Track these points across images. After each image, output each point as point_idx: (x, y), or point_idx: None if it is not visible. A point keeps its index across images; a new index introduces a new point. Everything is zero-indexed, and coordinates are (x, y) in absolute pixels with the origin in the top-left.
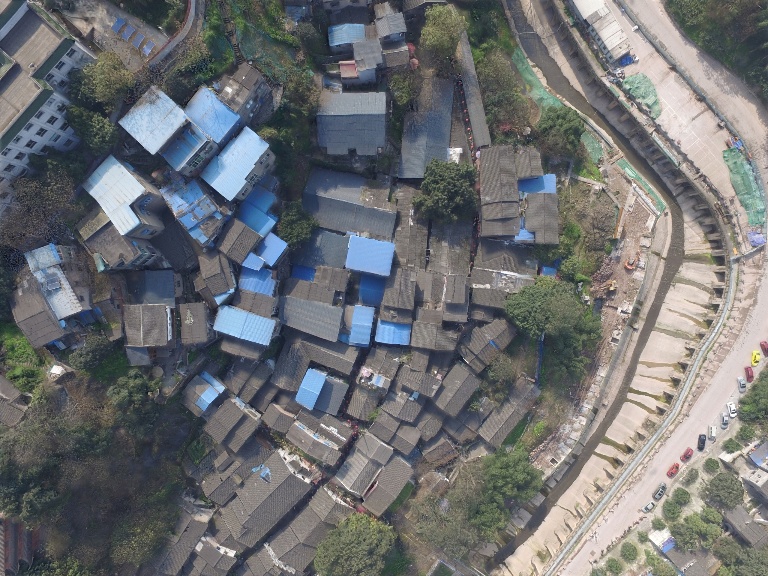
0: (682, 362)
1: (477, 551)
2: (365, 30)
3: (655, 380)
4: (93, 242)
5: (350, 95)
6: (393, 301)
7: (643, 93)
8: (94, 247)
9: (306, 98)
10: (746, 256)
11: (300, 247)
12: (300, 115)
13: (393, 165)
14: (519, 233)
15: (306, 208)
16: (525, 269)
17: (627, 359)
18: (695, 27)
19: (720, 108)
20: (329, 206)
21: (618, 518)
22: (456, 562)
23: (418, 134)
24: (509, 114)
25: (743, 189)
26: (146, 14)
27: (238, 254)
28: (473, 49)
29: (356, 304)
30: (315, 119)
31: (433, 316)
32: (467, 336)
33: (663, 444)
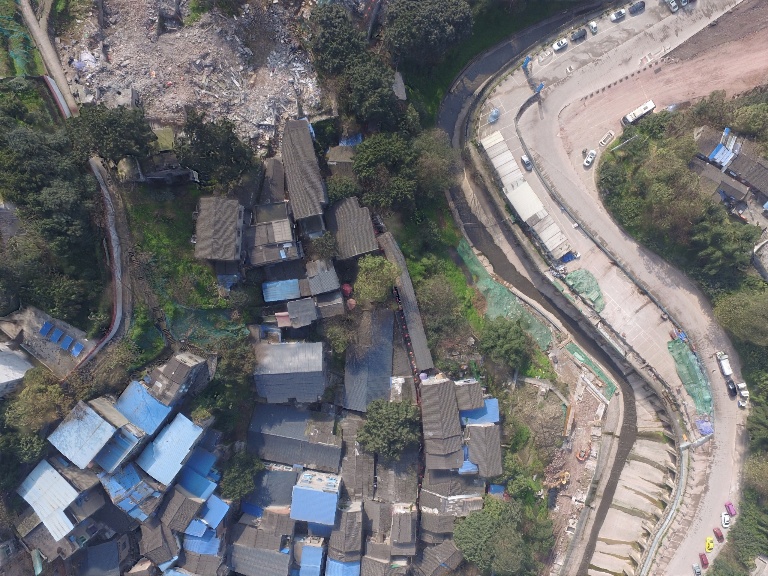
0: (639, 543)
1: None
2: (299, 285)
3: (614, 557)
4: (31, 537)
5: (287, 347)
6: (339, 545)
7: (586, 289)
8: (32, 542)
9: (241, 367)
10: (695, 444)
11: (244, 497)
12: (236, 383)
13: (337, 394)
14: (463, 465)
15: (252, 443)
16: (473, 488)
17: (586, 537)
18: (633, 226)
19: (662, 300)
20: (275, 441)
21: None
22: None
23: (359, 368)
24: (450, 337)
25: (689, 379)
26: (72, 322)
27: (180, 524)
28: (414, 263)
29: (306, 534)
30: (253, 378)
31: (381, 551)
32: (419, 556)
33: None
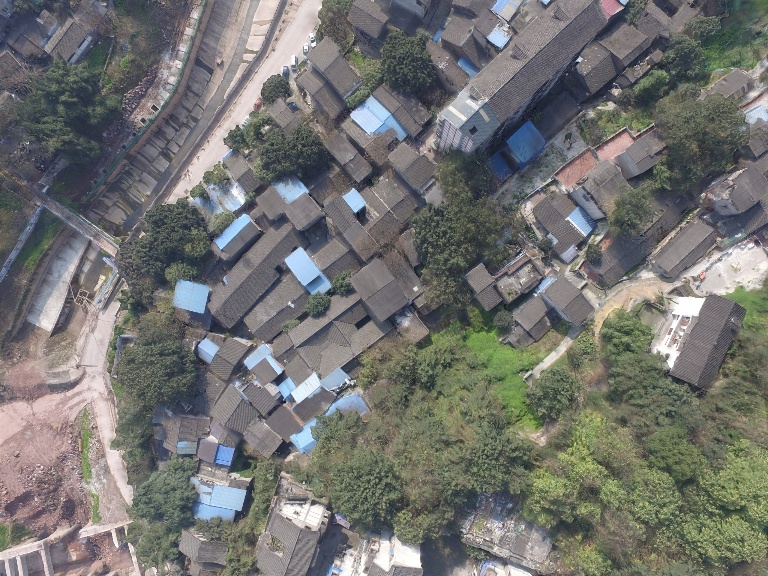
0: None
1: (103, 216)
2: None
3: None
4: None
5: None
6: None
7: None
8: None
9: None
10: None
11: None
12: None
13: None
14: None
15: None
16: None
17: (240, 19)
18: None
19: None
20: None
21: (210, 156)
22: (63, 210)
23: None
24: None
25: None
26: None
27: None
28: None
29: None
30: None
31: None
32: None
33: (250, 79)
